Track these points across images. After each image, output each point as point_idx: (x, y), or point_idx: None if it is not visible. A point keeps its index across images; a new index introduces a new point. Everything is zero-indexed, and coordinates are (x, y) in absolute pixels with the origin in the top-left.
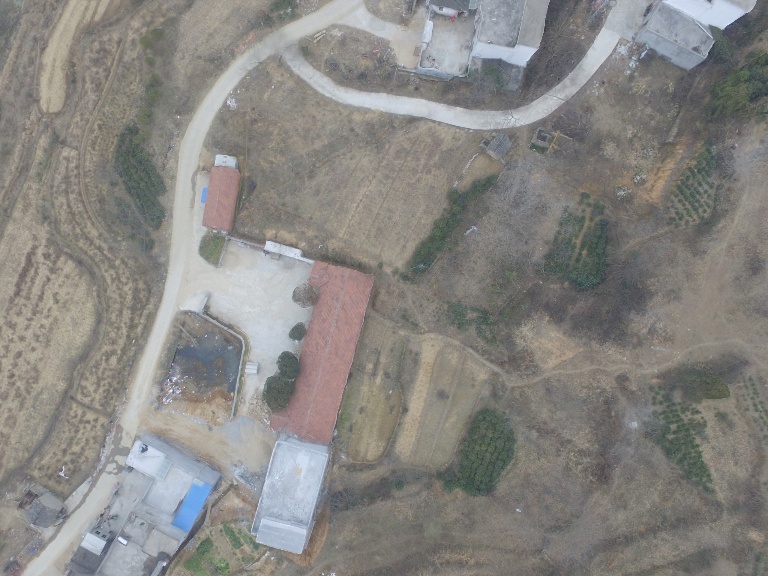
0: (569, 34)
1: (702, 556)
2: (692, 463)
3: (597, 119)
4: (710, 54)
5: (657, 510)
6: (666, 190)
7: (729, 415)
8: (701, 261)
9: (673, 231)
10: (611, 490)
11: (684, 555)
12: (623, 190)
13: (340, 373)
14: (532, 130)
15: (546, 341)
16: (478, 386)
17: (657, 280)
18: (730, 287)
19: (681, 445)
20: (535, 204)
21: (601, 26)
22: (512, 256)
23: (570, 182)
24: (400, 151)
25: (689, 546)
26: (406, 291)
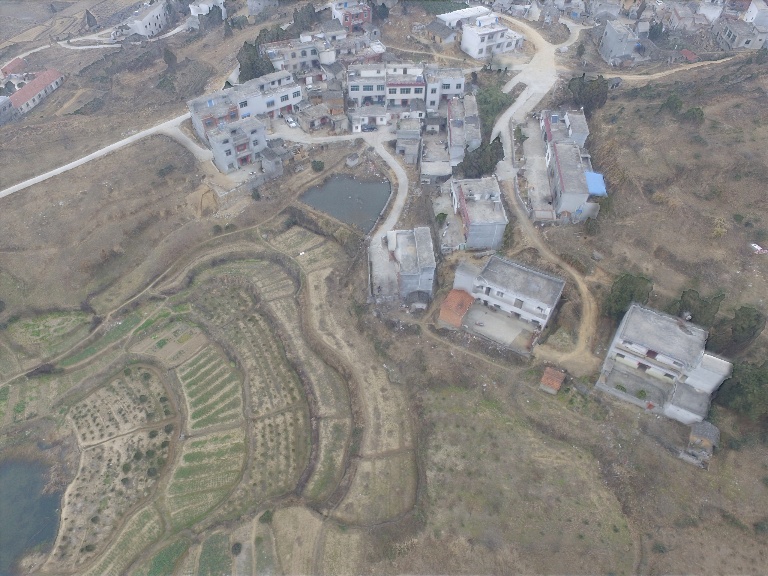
0: None
1: None
2: None
3: (169, 41)
4: None
5: None
6: None
7: None
8: None
9: None
10: None
11: None
12: None
13: (33, 92)
14: None
15: None
16: None
17: None
18: None
19: None
20: None
21: None
22: None
23: None
24: (91, 52)
25: None
26: (77, 79)
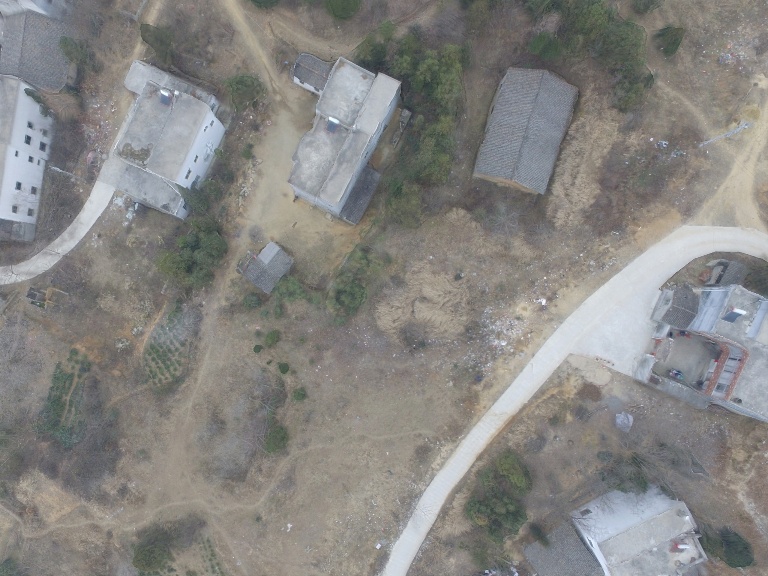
0: (70, 187)
1: None
2: None
3: (95, 272)
4: (188, 208)
5: None
6: (146, 347)
7: (198, 574)
8: (168, 421)
9: (152, 388)
10: None
11: None
12: (121, 342)
13: None
14: (33, 285)
15: (47, 496)
16: (5, 535)
17: (127, 441)
18: (196, 446)
19: None
20: (32, 360)
21: (95, 179)
22: (11, 412)
23: (69, 336)
24: None
25: None
26: None
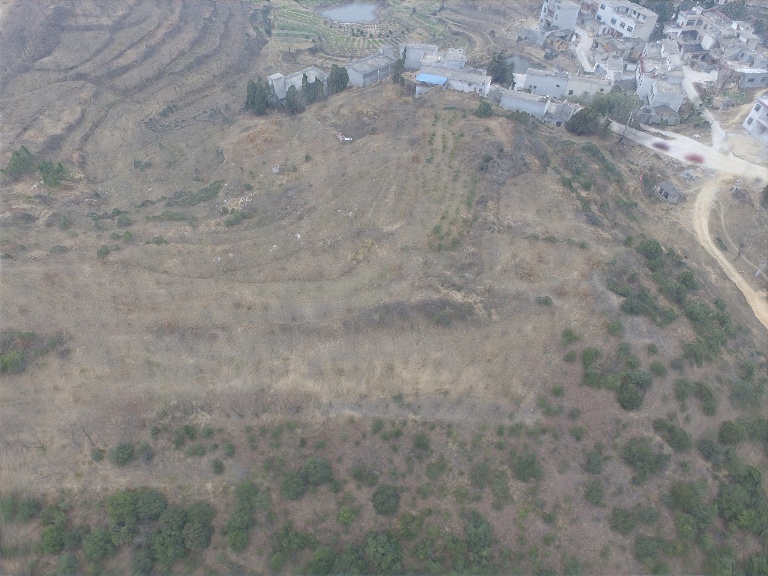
0: None
1: None
2: None
3: None
4: None
5: None
6: None
7: None
8: None
9: None
10: None
11: None
12: None
13: None
14: None
15: None
16: None
17: None
18: None
19: None
20: None
21: None
22: None
23: None
24: None
25: None
26: None
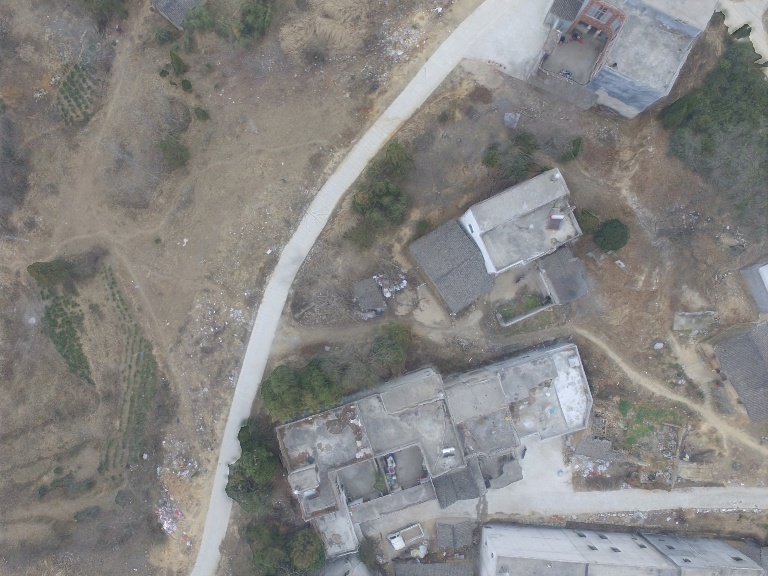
0: None
1: (79, 447)
2: (74, 356)
3: (17, 23)
4: None
5: (52, 404)
6: None
7: (100, 306)
8: (76, 155)
9: (65, 128)
10: (12, 385)
11: (69, 447)
12: (39, 92)
13: None
14: None
15: None
16: None
17: (36, 175)
18: (103, 180)
19: (65, 338)
20: None
21: None
22: None
23: None
24: None
25: (72, 438)
26: None
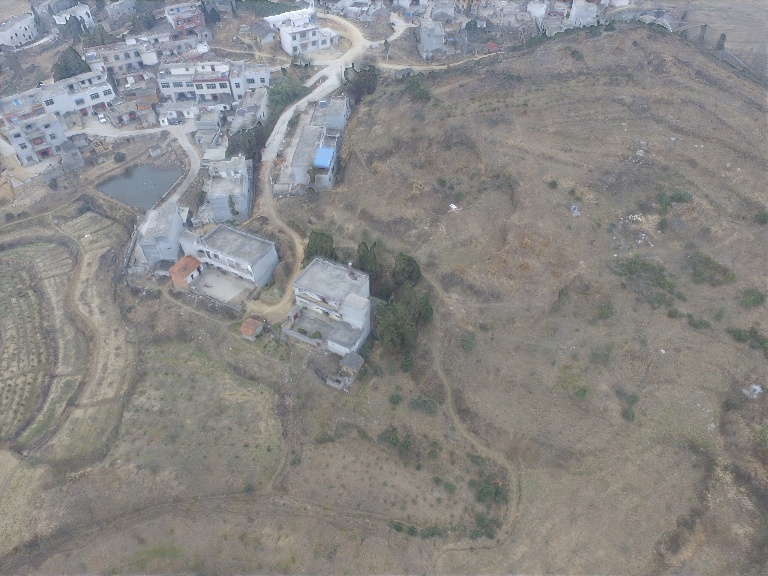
0: None
1: None
2: None
3: None
4: None
5: None
6: None
7: None
8: (40, 56)
9: None
10: None
11: None
12: None
13: None
14: None
15: None
16: None
17: (21, 61)
18: None
19: None
20: None
21: None
22: None
23: None
24: None
25: None
26: None
